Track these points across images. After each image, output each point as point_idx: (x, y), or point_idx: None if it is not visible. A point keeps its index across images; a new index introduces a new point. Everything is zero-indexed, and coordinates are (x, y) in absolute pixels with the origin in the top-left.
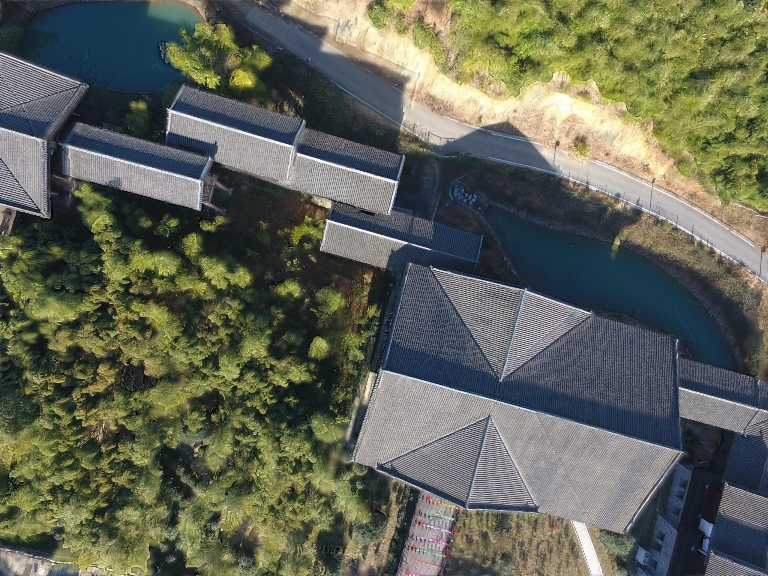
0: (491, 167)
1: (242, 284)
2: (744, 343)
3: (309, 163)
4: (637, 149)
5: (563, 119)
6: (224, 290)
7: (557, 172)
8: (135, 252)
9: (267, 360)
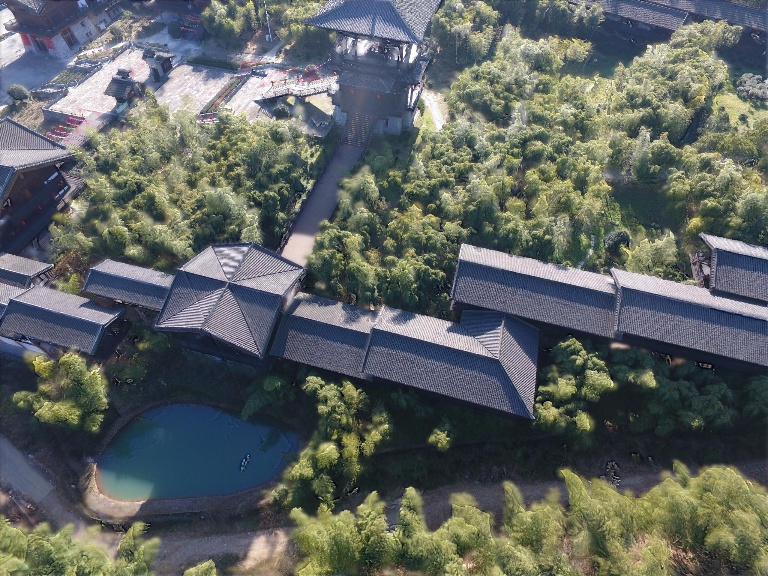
0: None
1: None
2: None
3: None
4: None
5: None
6: None
7: None
8: (169, 240)
9: (107, 191)
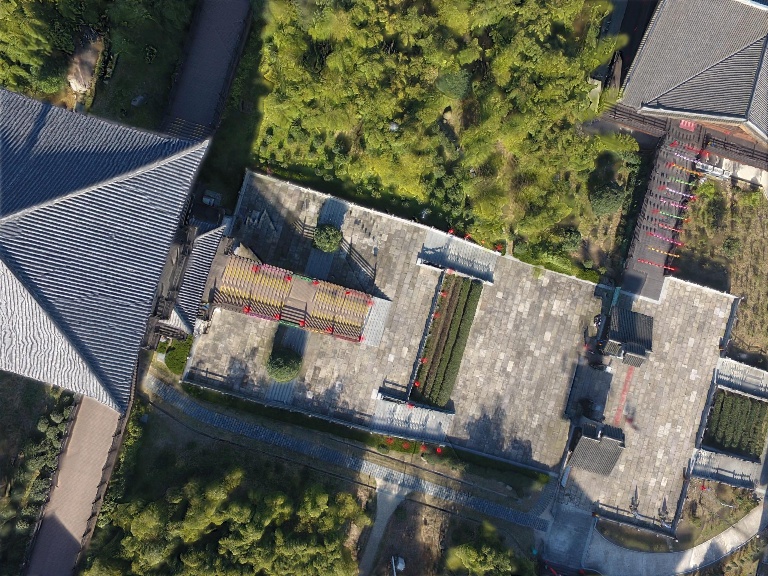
0: None
1: None
2: None
3: None
4: None
5: None
6: None
7: None
8: None
9: None
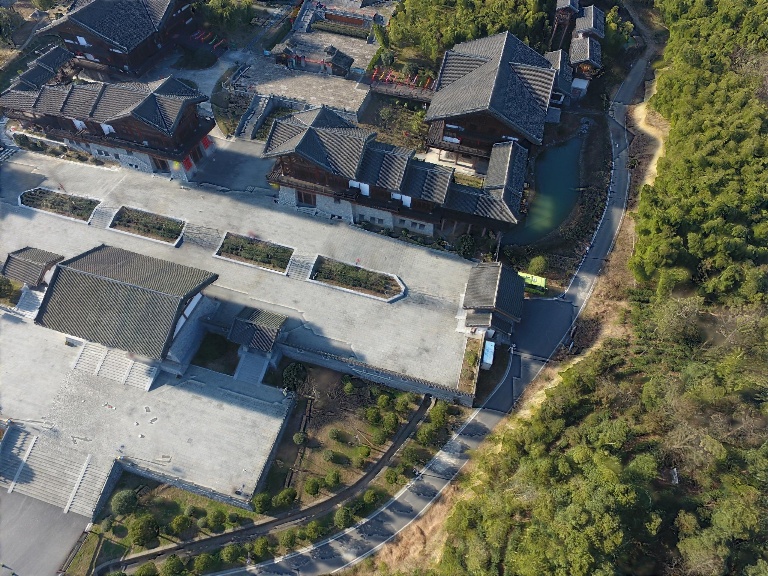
0: (606, 130)
1: (527, 23)
2: None
3: None
4: None
5: None
6: (523, 20)
7: (615, 157)
8: None
9: None
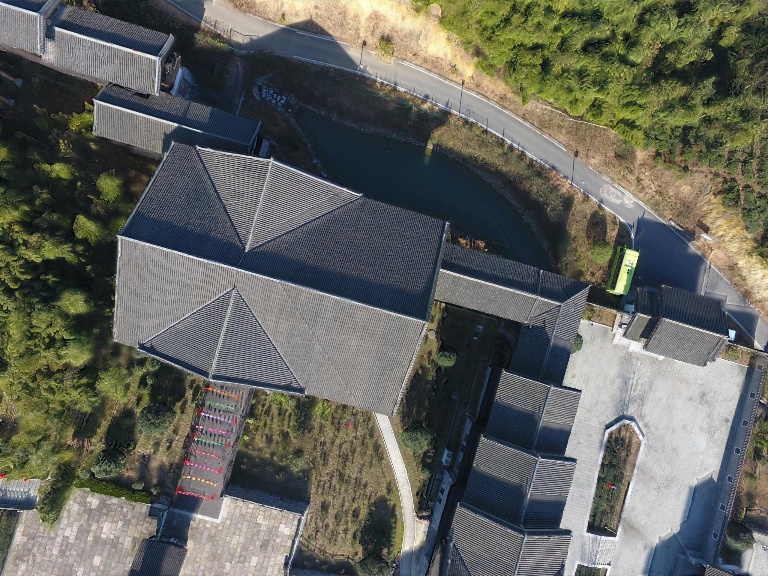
0: (295, 65)
1: None
2: (557, 248)
3: (69, 38)
4: (442, 48)
5: (366, 17)
6: None
7: (364, 72)
8: None
9: (19, 235)
